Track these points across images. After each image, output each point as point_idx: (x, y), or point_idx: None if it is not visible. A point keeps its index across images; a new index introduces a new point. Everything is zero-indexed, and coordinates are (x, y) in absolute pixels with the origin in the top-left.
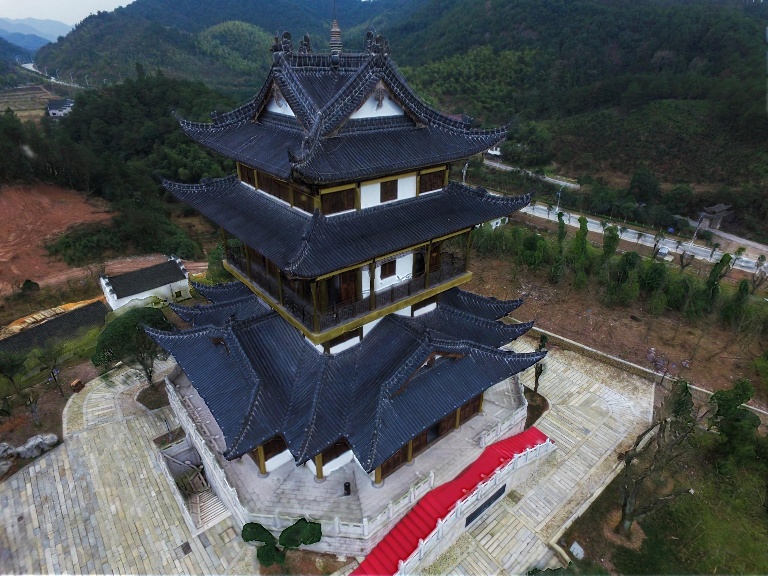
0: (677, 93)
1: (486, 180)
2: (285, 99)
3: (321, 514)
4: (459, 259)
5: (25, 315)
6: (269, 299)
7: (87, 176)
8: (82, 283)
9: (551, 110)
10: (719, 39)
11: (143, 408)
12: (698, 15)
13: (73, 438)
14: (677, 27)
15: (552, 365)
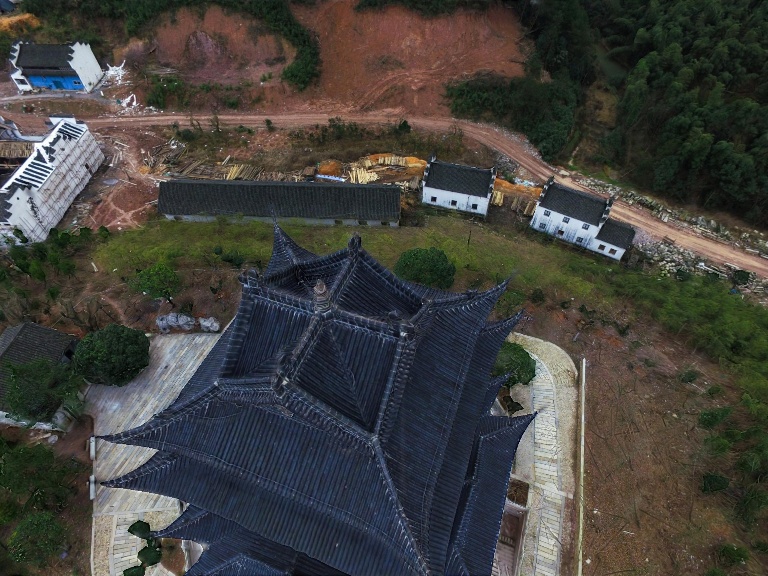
0: None
1: None
2: None
3: (202, 550)
4: None
5: (387, 151)
6: None
7: (537, 13)
8: (442, 139)
9: None
10: None
11: None
12: None
13: None
14: None
15: None
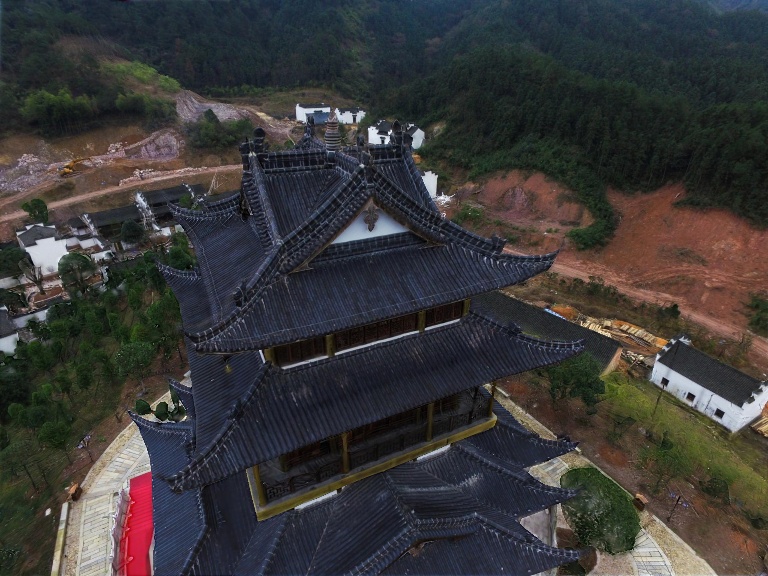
0: None
1: None
2: None
3: None
4: (277, 486)
5: (638, 324)
6: None
7: None
8: (719, 342)
9: None
10: None
11: None
12: None
13: None
14: None
15: None
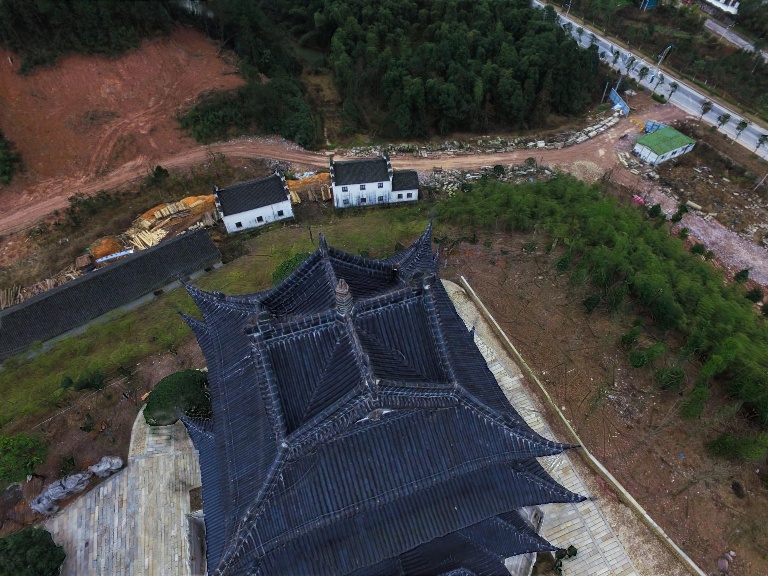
0: None
1: None
2: None
3: None
4: None
5: (156, 203)
6: None
7: (221, 24)
8: (205, 169)
9: None
10: None
11: (190, 444)
12: None
13: (134, 464)
14: None
15: (594, 523)
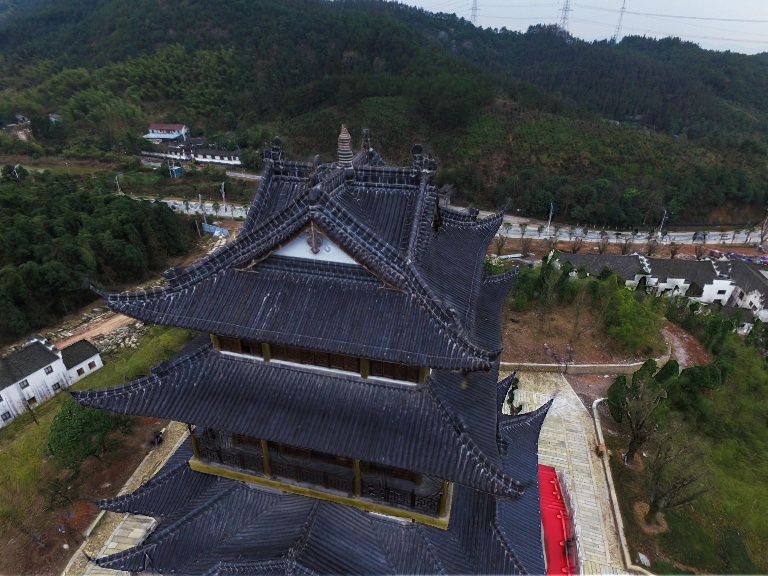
0: (379, 91)
1: (241, 194)
2: (338, 246)
3: None
4: None
5: None
6: (332, 495)
7: None
8: None
9: (271, 111)
10: (388, 42)
11: None
12: (366, 20)
13: None
14: (354, 30)
15: None
